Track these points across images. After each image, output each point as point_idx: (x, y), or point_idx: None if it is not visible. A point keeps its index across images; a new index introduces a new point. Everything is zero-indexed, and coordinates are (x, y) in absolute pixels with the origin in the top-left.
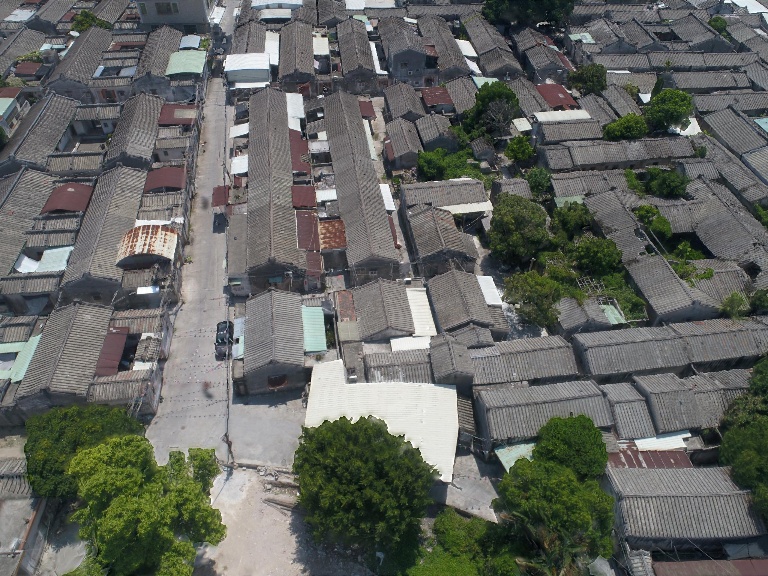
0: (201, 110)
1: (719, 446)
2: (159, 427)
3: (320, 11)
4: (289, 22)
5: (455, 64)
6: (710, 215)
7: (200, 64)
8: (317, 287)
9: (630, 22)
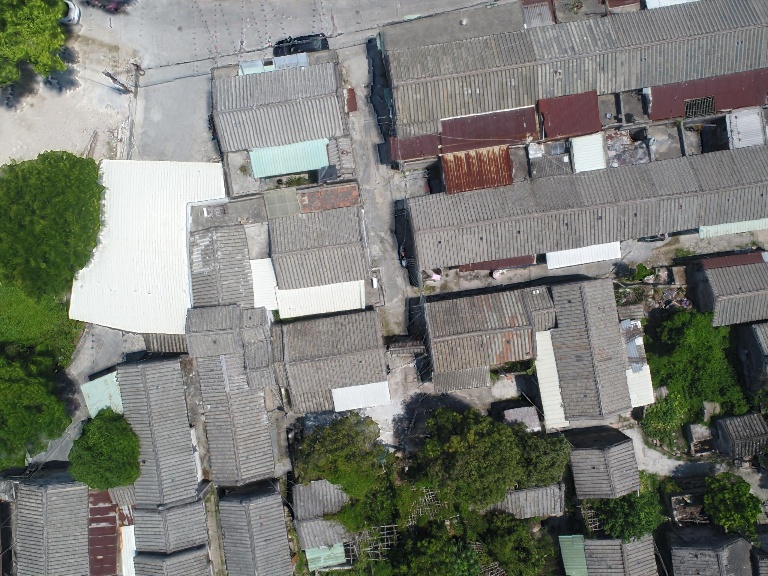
0: None
1: None
2: (180, 2)
3: None
4: None
5: None
6: None
7: None
8: None
9: None
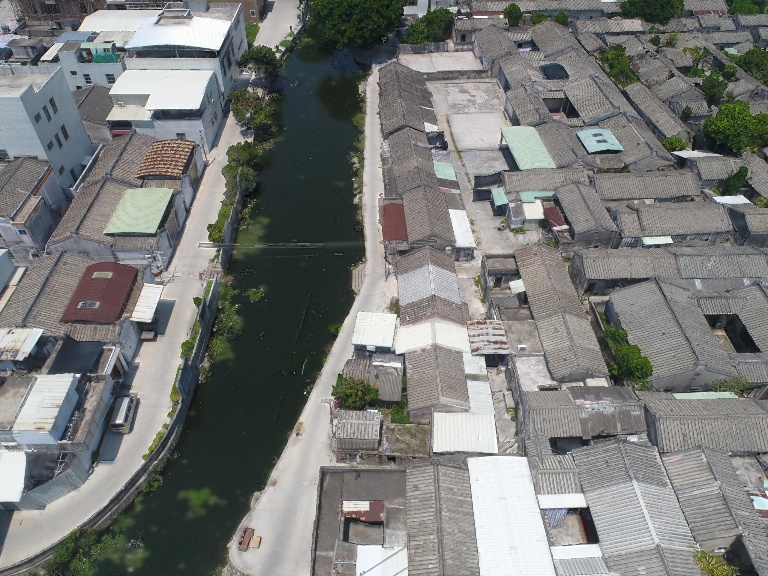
0: None
1: None
2: None
3: None
4: None
5: None
6: None
7: None
8: None
9: None
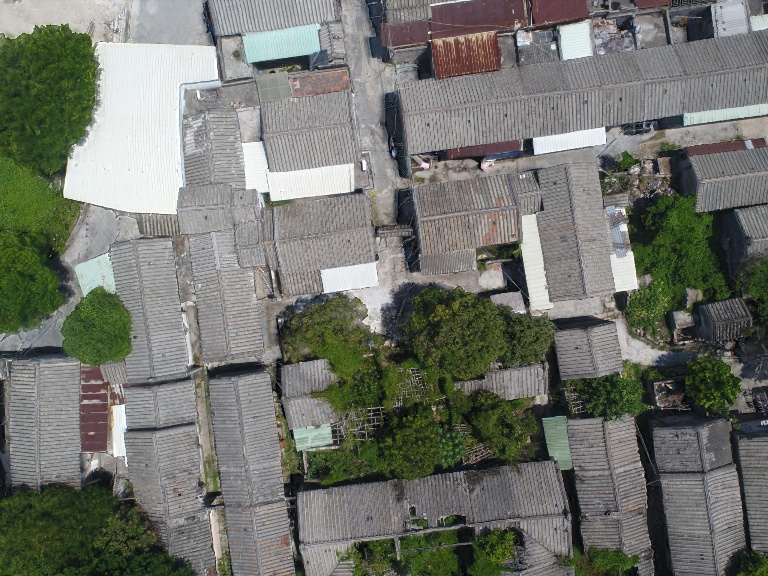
0: None
1: (110, 491)
2: None
3: None
4: None
5: None
6: None
7: None
8: None
9: None
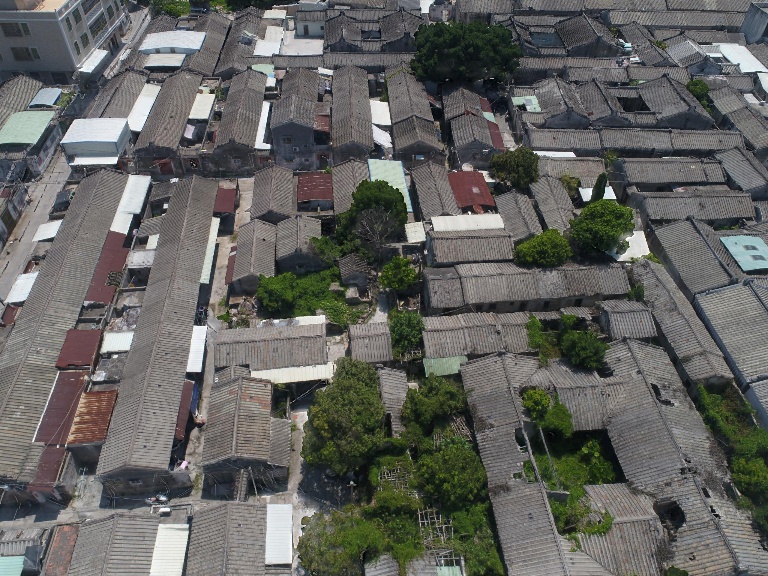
0: (25, 193)
1: None
2: None
3: (222, 57)
4: (177, 72)
5: (352, 140)
6: (629, 406)
7: (38, 131)
8: (57, 498)
9: (589, 83)
